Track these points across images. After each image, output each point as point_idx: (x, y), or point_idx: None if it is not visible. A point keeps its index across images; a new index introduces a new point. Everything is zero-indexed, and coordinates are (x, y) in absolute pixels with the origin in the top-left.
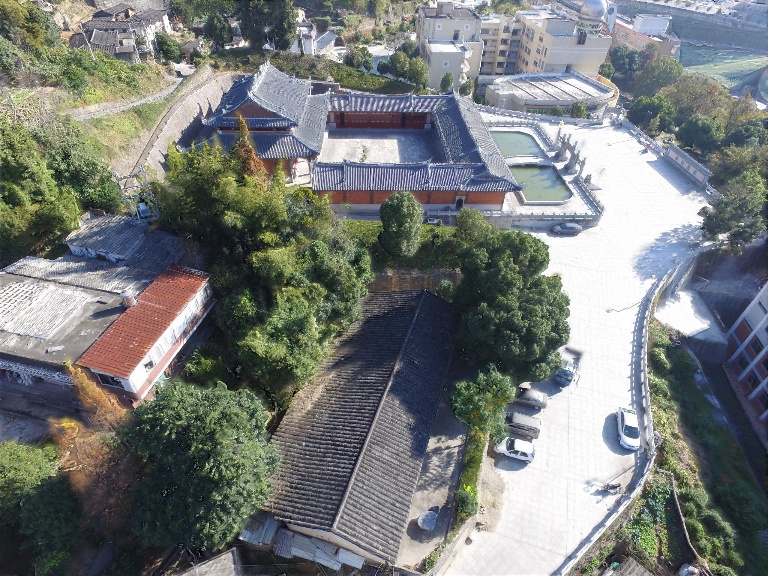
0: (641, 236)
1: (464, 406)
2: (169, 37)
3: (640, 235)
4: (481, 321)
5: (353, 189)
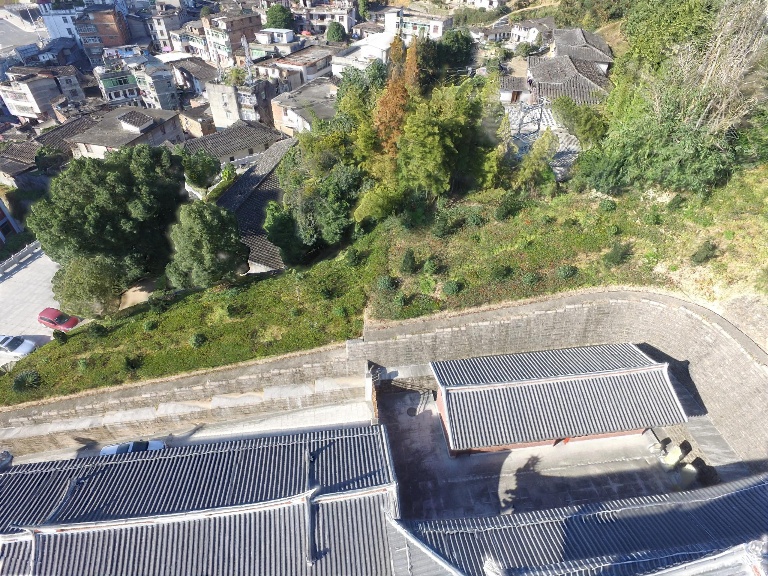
0: None
1: (213, 158)
2: None
3: None
4: (173, 161)
5: (288, 437)
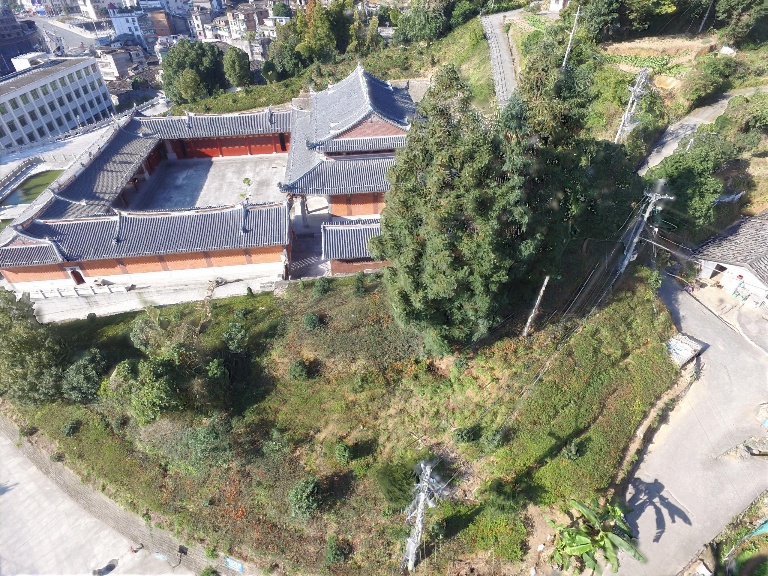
0: (15, 165)
1: None
2: (669, 160)
3: (14, 166)
4: (219, 52)
5: None
